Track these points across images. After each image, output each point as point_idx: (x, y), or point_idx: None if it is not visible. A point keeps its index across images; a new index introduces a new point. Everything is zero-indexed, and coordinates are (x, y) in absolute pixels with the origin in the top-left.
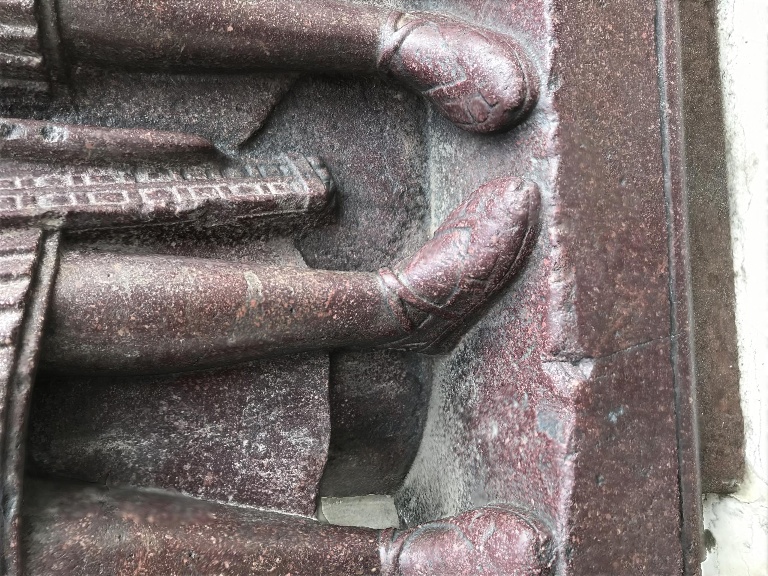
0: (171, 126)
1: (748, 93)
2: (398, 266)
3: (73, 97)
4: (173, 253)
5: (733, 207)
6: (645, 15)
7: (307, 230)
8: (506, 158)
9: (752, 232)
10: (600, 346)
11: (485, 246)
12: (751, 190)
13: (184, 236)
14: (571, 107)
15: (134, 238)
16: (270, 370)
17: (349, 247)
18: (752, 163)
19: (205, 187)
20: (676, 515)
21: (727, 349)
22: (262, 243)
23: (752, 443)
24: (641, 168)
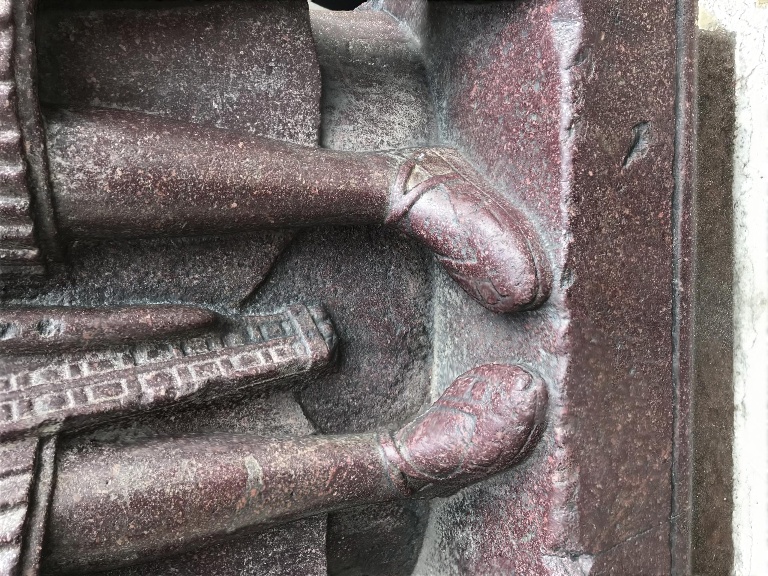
0: (171, 290)
1: (760, 230)
2: (400, 436)
3: (70, 272)
4: (172, 427)
5: (737, 341)
6: (663, 193)
7: (308, 382)
8: (514, 335)
9: (755, 371)
10: (600, 542)
11: (489, 440)
12: (757, 329)
13: (183, 410)
14: (583, 302)
15: (132, 421)
16: (268, 529)
17: (350, 395)
18: (759, 302)
19: (206, 363)
20: None
21: (722, 482)
22: (262, 401)
23: (741, 575)
24: (650, 354)
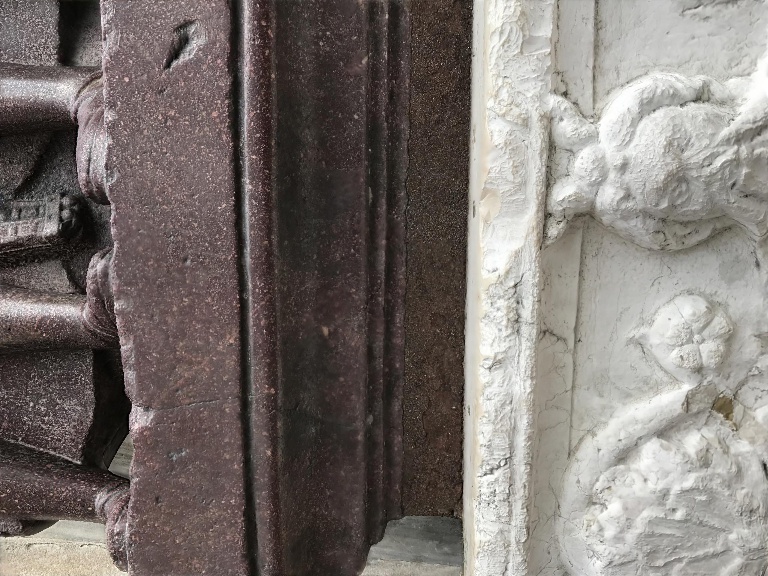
0: None
1: None
2: None
3: None
4: None
5: None
6: (216, 92)
7: (71, 254)
8: None
9: (469, 278)
10: (160, 400)
11: None
12: (470, 232)
13: None
14: (127, 197)
15: None
16: (47, 357)
17: None
18: (470, 202)
19: None
20: (240, 541)
21: (450, 390)
22: (37, 264)
23: None
24: (209, 247)
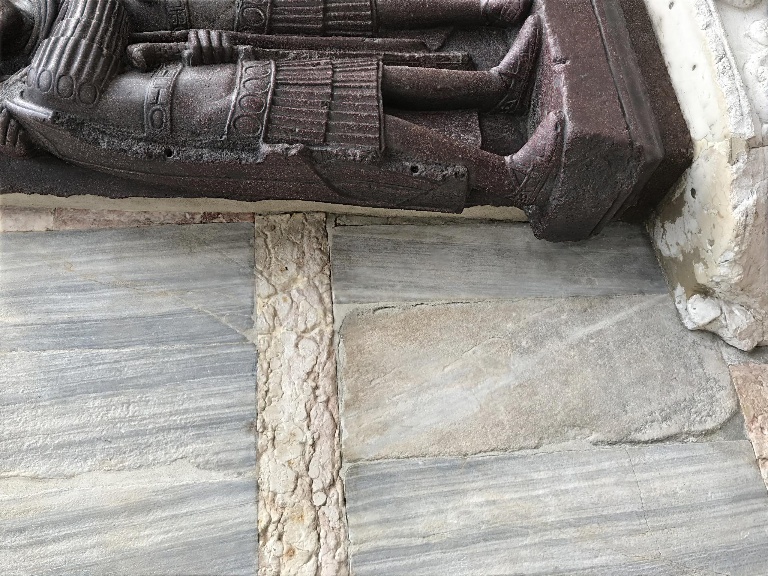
0: None
1: None
2: None
3: None
4: None
5: (659, 43)
6: None
7: None
8: None
9: (667, 46)
10: (572, 56)
11: (524, 38)
12: (662, 31)
13: None
14: None
15: None
16: (454, 116)
17: None
18: (660, 21)
19: None
20: None
21: (670, 96)
22: None
23: (691, 129)
24: (582, 7)
